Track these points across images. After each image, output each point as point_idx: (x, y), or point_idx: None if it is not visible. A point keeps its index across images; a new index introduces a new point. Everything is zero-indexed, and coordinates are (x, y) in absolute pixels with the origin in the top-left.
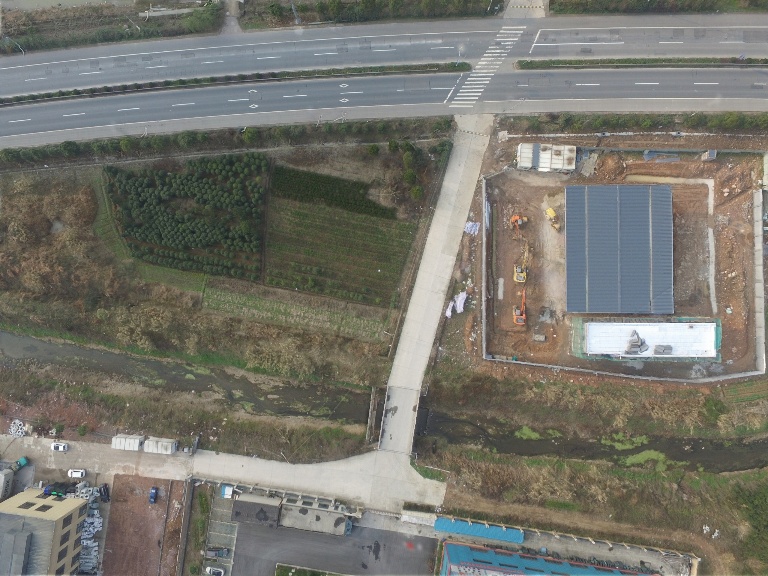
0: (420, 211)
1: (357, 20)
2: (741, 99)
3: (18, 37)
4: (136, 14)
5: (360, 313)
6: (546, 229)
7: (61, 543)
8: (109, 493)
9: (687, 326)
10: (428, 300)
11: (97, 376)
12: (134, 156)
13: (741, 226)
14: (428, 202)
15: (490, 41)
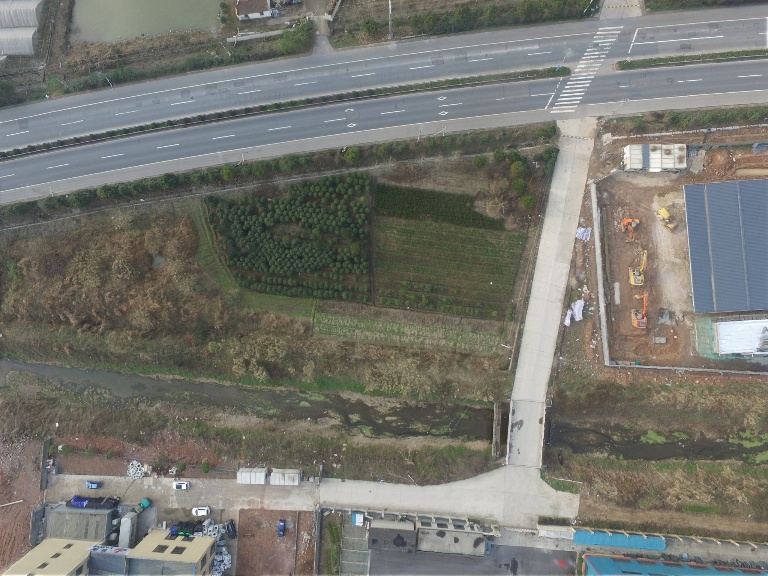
0: (528, 220)
1: (452, 31)
2: None
3: (107, 71)
4: (223, 40)
5: (476, 328)
6: (658, 230)
7: None
8: (236, 529)
9: None
10: (545, 310)
11: (209, 410)
12: (232, 184)
13: None
14: (537, 211)
15: (588, 43)
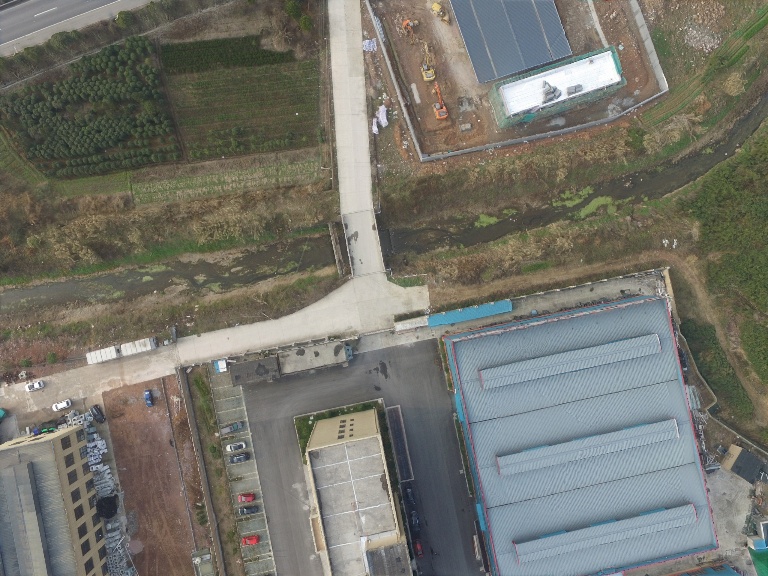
0: (316, 46)
1: None
2: None
3: None
4: None
5: (292, 159)
6: (438, 26)
7: (66, 464)
8: (102, 413)
9: (588, 62)
10: (352, 124)
11: (51, 311)
12: (12, 79)
13: None
14: (320, 33)
15: None
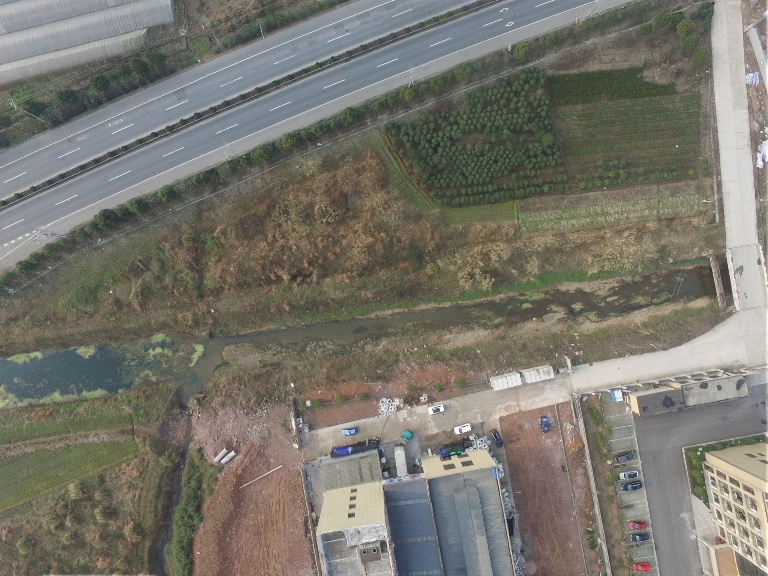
0: (697, 78)
1: None
2: None
3: None
4: None
5: (674, 191)
6: None
7: None
8: (500, 437)
9: None
10: (737, 158)
11: (436, 335)
12: (405, 108)
13: None
14: (705, 66)
15: None
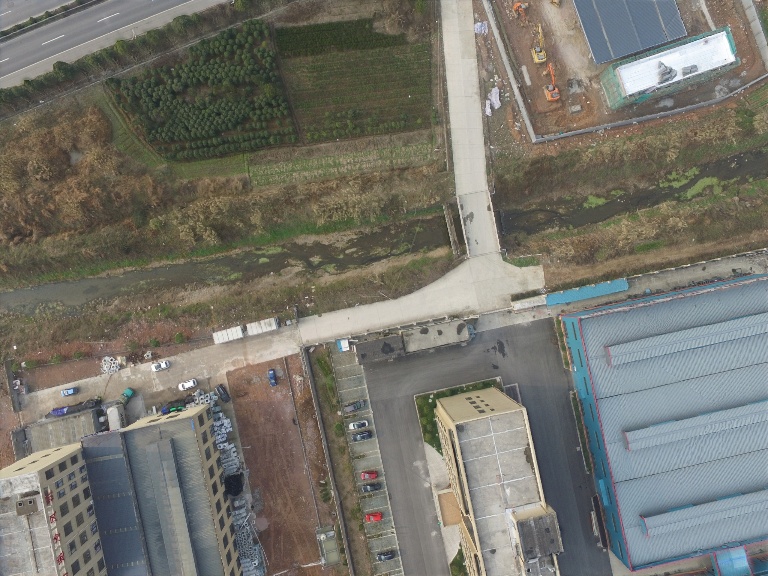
0: (428, 29)
1: None
2: None
3: None
4: None
5: (406, 141)
6: (547, 8)
7: (203, 441)
8: (227, 392)
9: (702, 43)
10: (465, 106)
11: (170, 292)
12: (130, 63)
13: None
14: (433, 16)
15: None
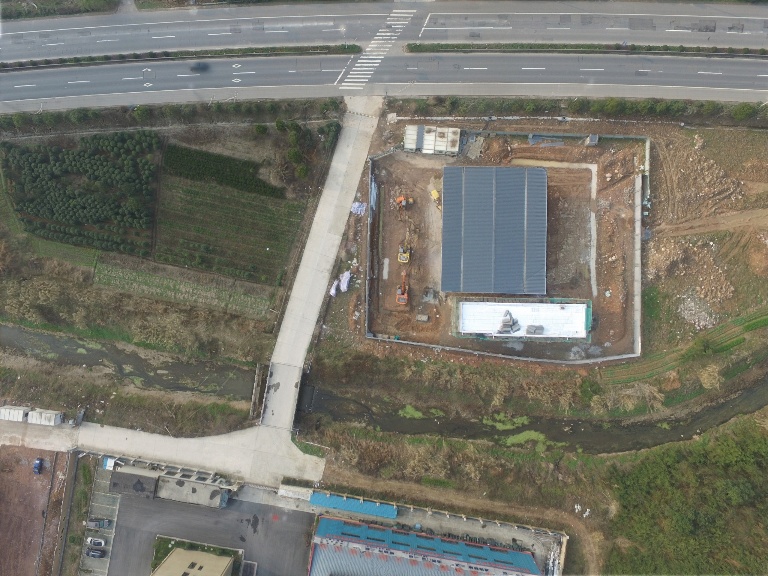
0: (309, 191)
1: (250, 1)
2: (626, 85)
3: None
4: None
5: (247, 290)
6: (432, 211)
7: None
8: None
9: (559, 307)
10: (313, 278)
11: None
12: (30, 132)
13: (622, 211)
14: (316, 182)
15: (381, 24)
